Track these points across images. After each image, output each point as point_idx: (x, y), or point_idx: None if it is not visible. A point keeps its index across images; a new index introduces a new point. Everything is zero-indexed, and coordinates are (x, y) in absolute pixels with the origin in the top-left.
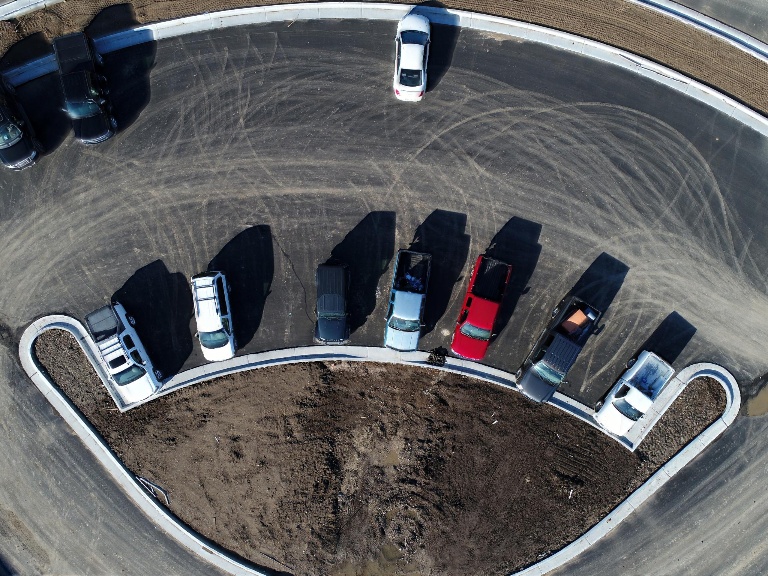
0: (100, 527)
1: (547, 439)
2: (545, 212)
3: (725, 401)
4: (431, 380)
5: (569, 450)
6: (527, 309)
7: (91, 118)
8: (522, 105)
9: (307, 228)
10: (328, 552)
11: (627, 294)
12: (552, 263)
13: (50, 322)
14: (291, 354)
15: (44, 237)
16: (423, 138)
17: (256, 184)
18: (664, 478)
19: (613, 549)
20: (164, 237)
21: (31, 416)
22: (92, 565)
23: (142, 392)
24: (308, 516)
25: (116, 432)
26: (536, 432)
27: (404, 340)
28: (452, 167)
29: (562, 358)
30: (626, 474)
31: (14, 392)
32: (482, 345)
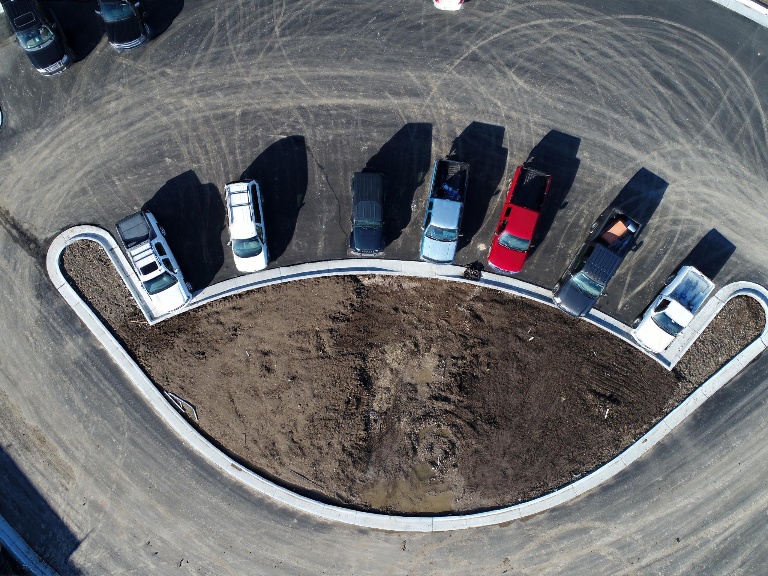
0: (127, 443)
1: (584, 357)
2: (584, 126)
3: (764, 321)
4: (466, 295)
5: (606, 368)
6: (565, 224)
7: (124, 21)
8: (562, 17)
9: (342, 139)
10: (359, 470)
11: (666, 210)
12: (590, 178)
13: (79, 233)
14: (324, 267)
15: (73, 146)
16: (461, 49)
17: (290, 94)
18: (701, 398)
19: (649, 470)
20: (196, 147)
21: (58, 329)
22: (118, 481)
23: (173, 301)
24: (340, 433)
25: (145, 345)
26: (573, 349)
27: (441, 250)
28: (490, 79)
29: (602, 269)
30: (663, 394)
31: (41, 304)
32: (520, 257)
